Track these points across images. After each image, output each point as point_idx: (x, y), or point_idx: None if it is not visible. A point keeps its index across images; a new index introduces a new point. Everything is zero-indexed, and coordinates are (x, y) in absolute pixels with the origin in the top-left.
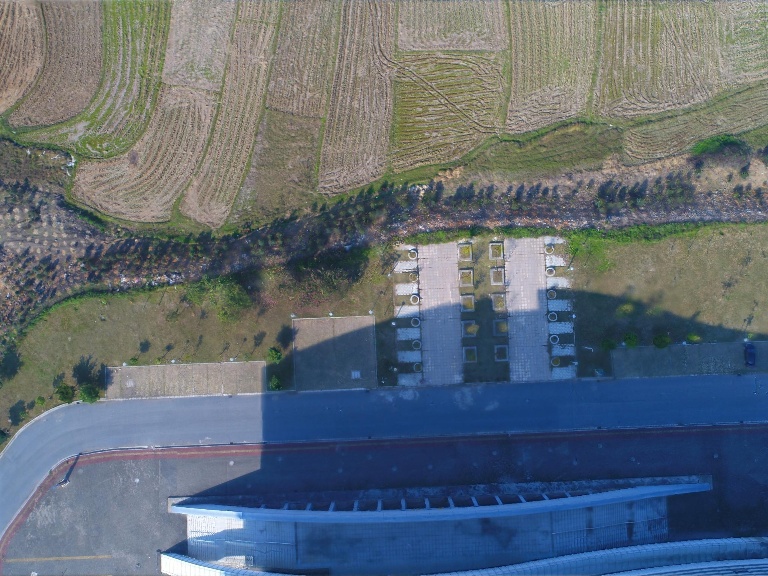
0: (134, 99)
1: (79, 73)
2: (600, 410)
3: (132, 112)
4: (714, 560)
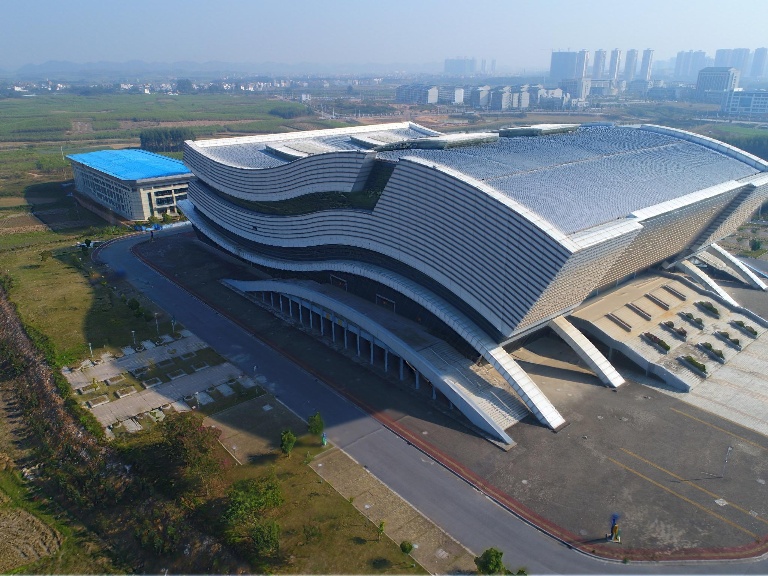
0: None
1: None
2: None
3: None
4: (262, 254)
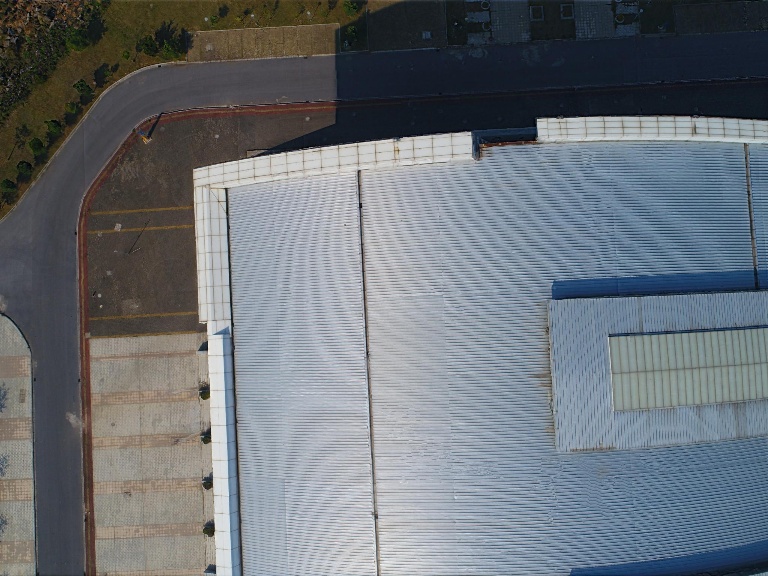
0: None
1: None
2: (663, 65)
3: None
4: None
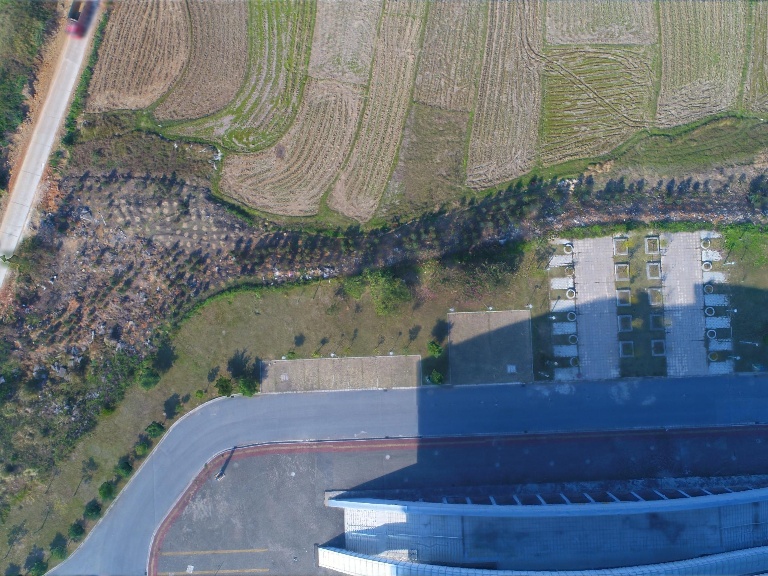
0: (280, 93)
1: (225, 67)
2: (757, 405)
3: (278, 106)
4: None
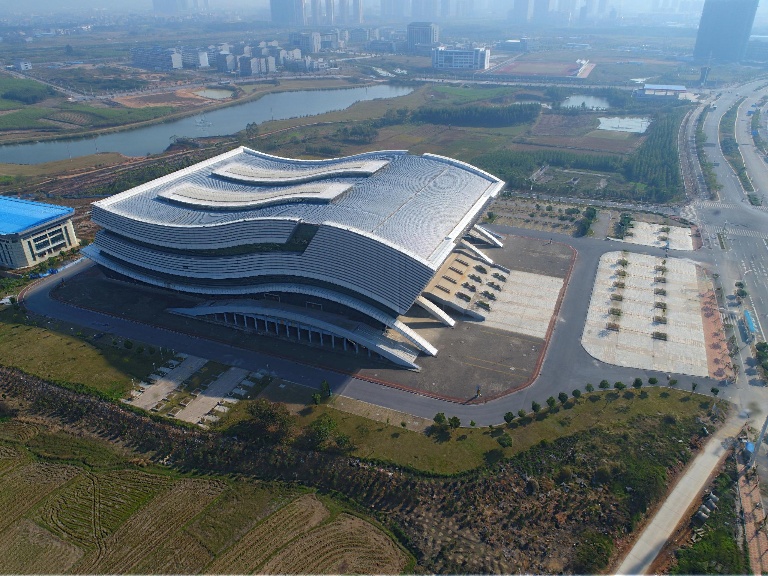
0: None
1: None
2: (182, 341)
3: None
4: (191, 284)
